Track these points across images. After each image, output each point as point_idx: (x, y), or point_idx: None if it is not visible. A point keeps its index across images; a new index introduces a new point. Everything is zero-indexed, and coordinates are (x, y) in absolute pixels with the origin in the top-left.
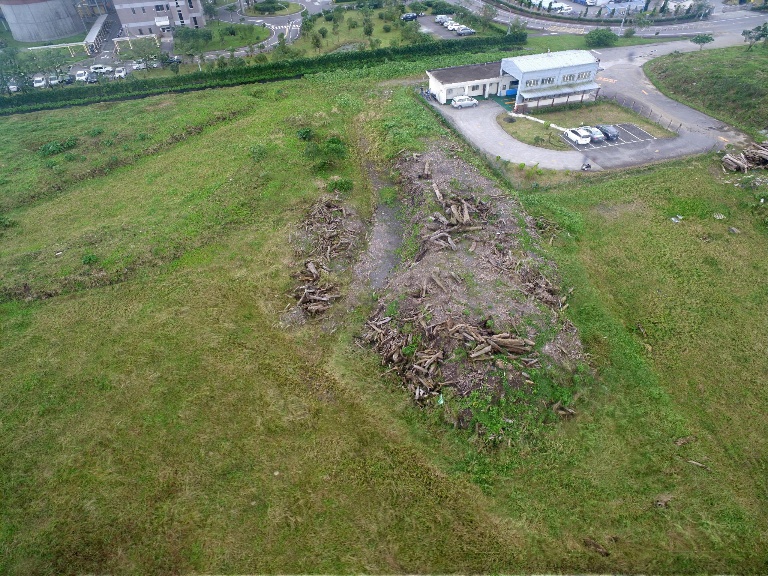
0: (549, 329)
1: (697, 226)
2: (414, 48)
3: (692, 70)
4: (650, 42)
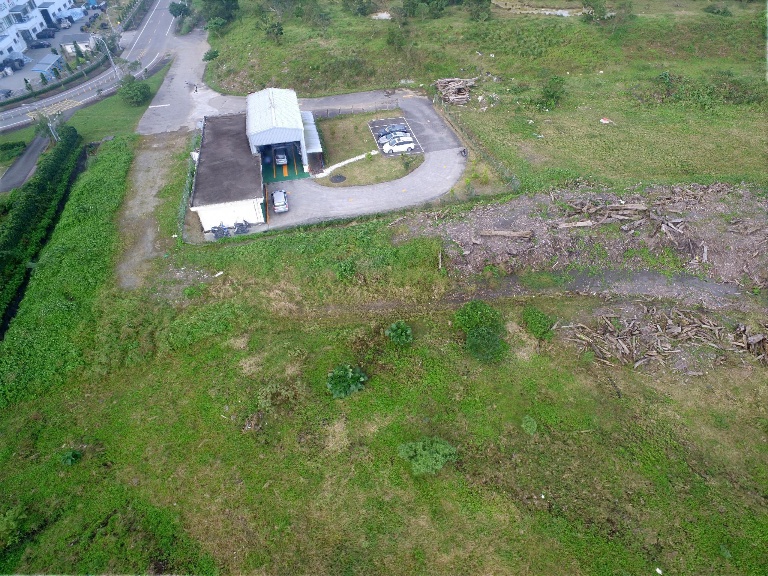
0: (762, 188)
1: (547, 131)
2: (17, 224)
3: (285, 73)
4: (160, 79)
